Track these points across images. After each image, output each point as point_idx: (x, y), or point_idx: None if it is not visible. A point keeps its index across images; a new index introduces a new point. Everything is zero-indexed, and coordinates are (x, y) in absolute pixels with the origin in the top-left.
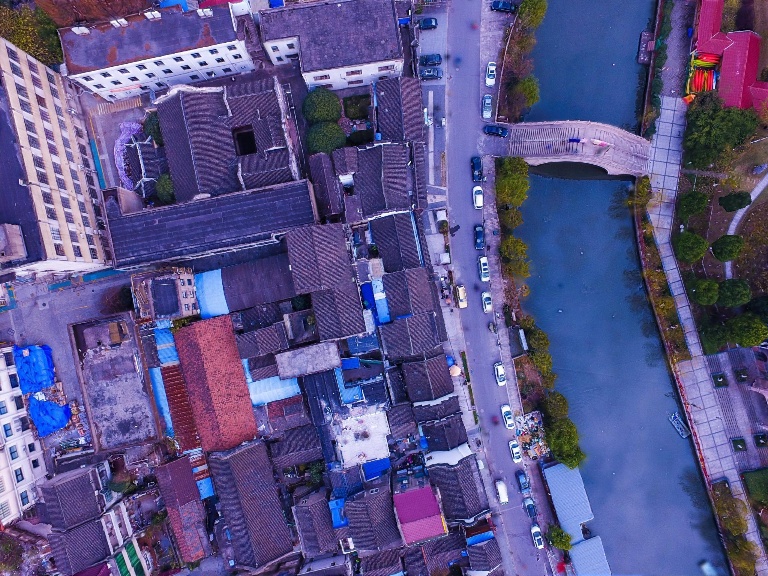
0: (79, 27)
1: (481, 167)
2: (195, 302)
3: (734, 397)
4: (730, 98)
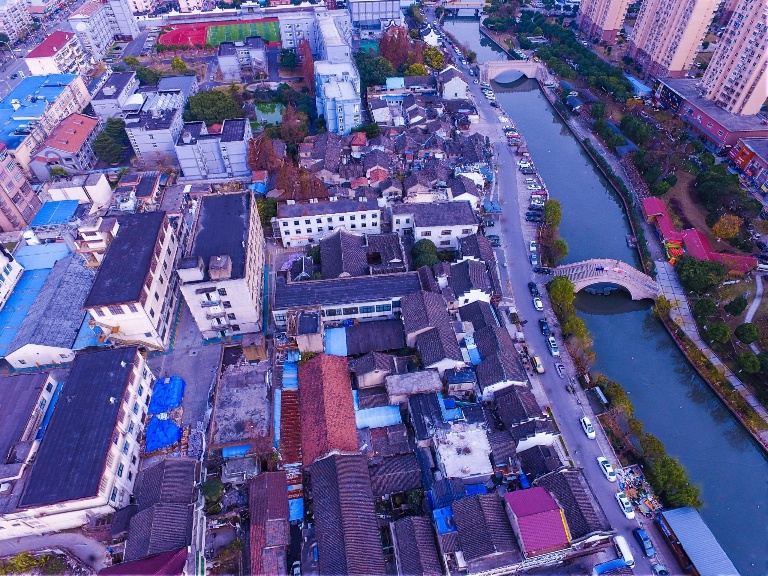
0: (291, 200)
1: None
2: (323, 342)
3: None
4: (699, 257)
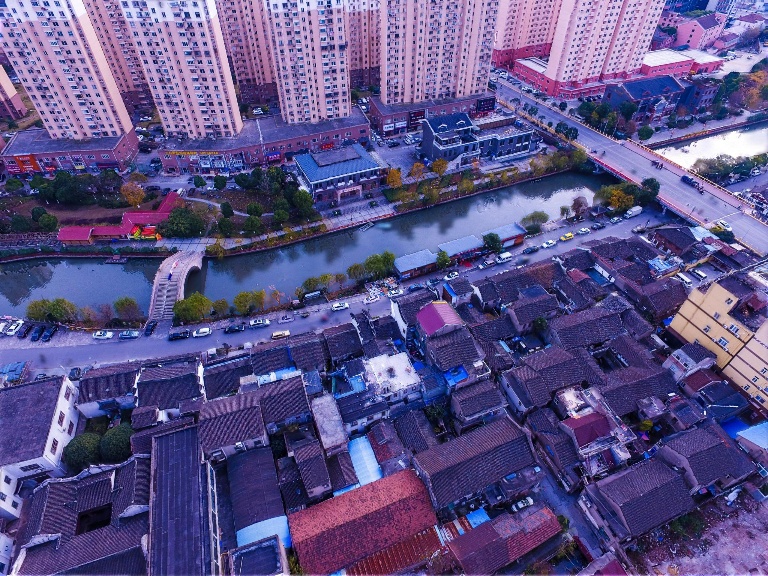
0: None
1: None
2: None
3: (346, 208)
4: (163, 218)
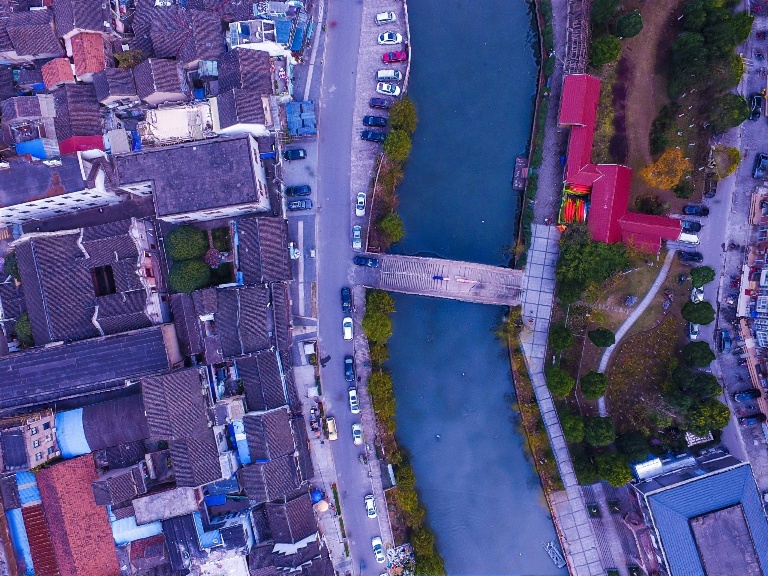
0: None
1: (352, 297)
2: (54, 444)
3: (608, 528)
4: (598, 232)
